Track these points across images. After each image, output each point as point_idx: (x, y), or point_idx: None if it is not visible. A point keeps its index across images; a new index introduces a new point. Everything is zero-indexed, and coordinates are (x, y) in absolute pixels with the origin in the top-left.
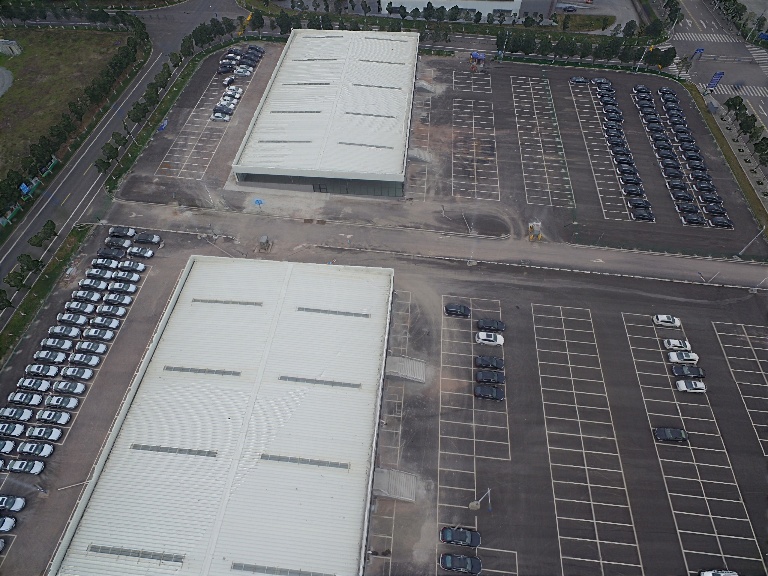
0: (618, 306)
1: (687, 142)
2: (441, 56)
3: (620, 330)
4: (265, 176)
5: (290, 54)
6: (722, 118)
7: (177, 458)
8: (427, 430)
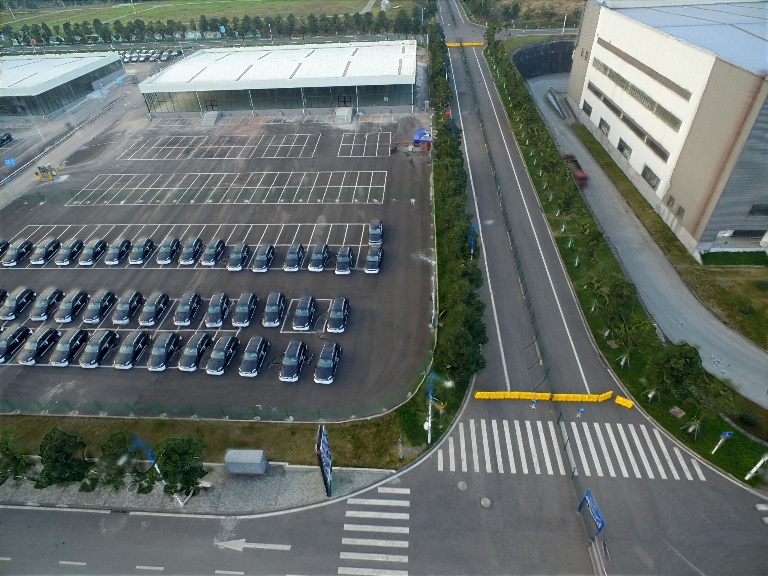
0: None
1: None
2: None
3: None
4: None
5: None
6: None
7: None
8: None
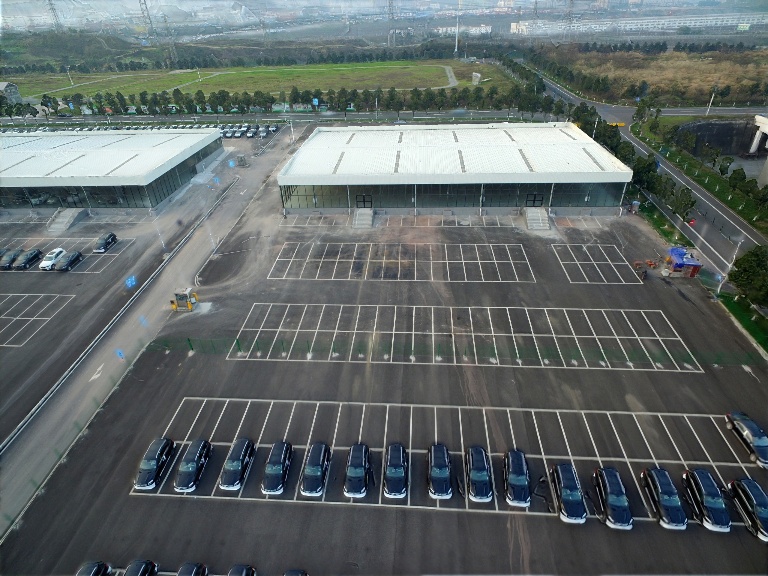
0: None
1: None
2: (658, 233)
3: None
4: None
5: (517, 128)
6: None
7: (64, 143)
8: (5, 232)
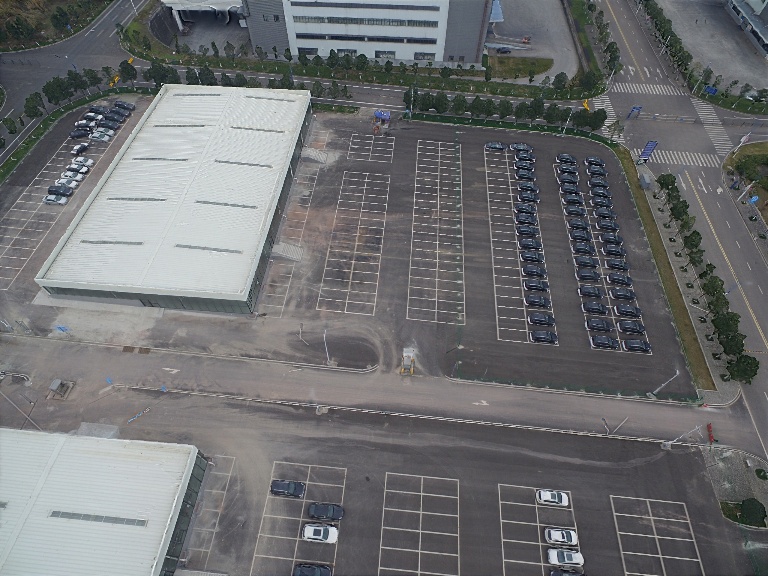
0: (495, 474)
1: (610, 230)
2: (342, 114)
3: (492, 512)
4: (79, 290)
5: (153, 117)
6: (655, 195)
7: None
8: None
